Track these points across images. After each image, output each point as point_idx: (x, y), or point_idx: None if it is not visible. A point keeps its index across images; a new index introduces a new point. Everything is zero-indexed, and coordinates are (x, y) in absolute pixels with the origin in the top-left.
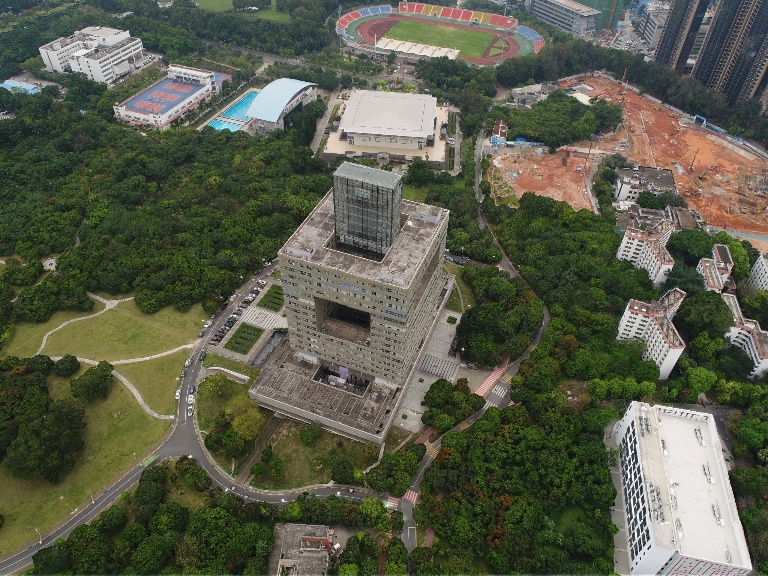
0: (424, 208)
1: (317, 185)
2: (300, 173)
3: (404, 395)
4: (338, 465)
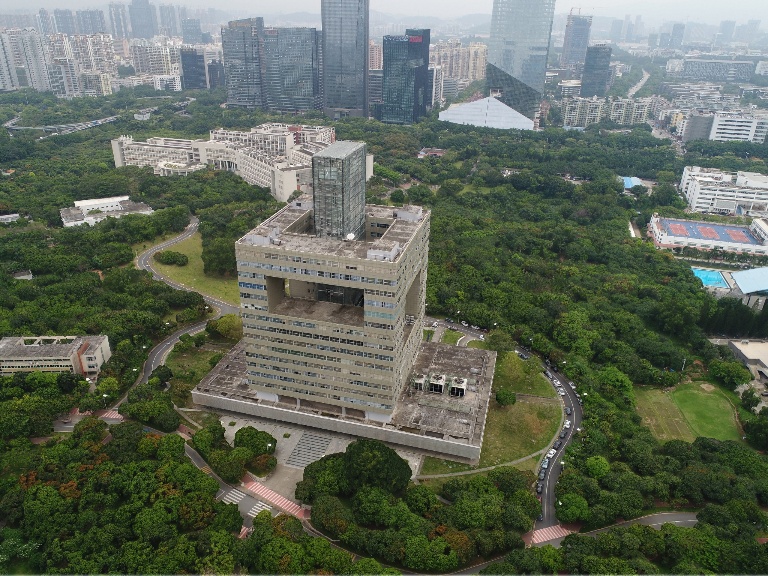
0: (386, 242)
1: (628, 332)
2: (662, 330)
3: (264, 422)
4: (166, 367)
